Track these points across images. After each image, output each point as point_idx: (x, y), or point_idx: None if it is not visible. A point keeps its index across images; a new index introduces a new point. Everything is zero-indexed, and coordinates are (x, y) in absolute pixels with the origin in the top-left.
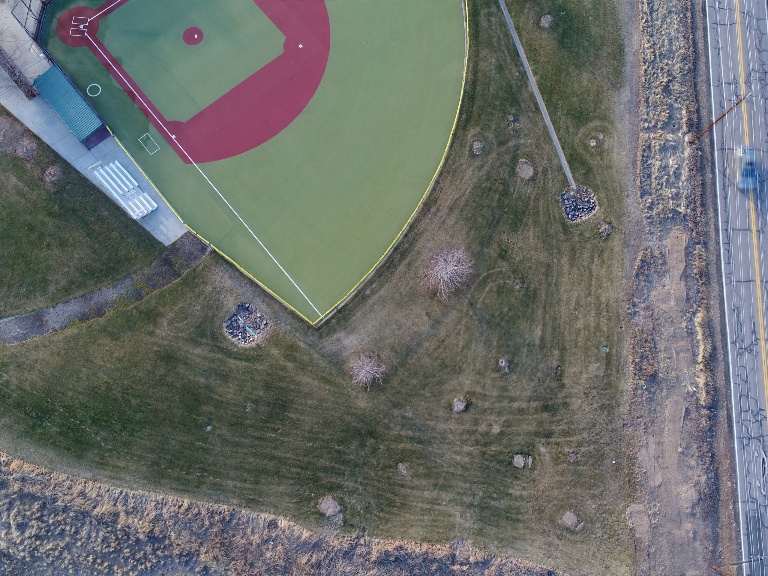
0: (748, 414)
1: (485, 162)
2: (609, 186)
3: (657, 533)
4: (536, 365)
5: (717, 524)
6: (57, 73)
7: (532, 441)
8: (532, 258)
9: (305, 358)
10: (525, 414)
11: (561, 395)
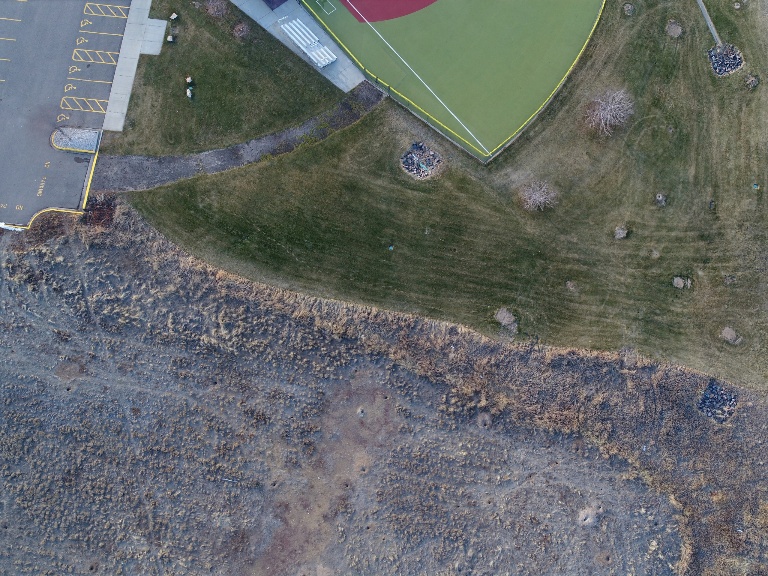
0: None
1: (636, 22)
2: (754, 44)
3: None
4: (691, 200)
5: None
6: None
7: (690, 265)
8: (683, 106)
9: (476, 190)
10: (682, 242)
11: (716, 226)
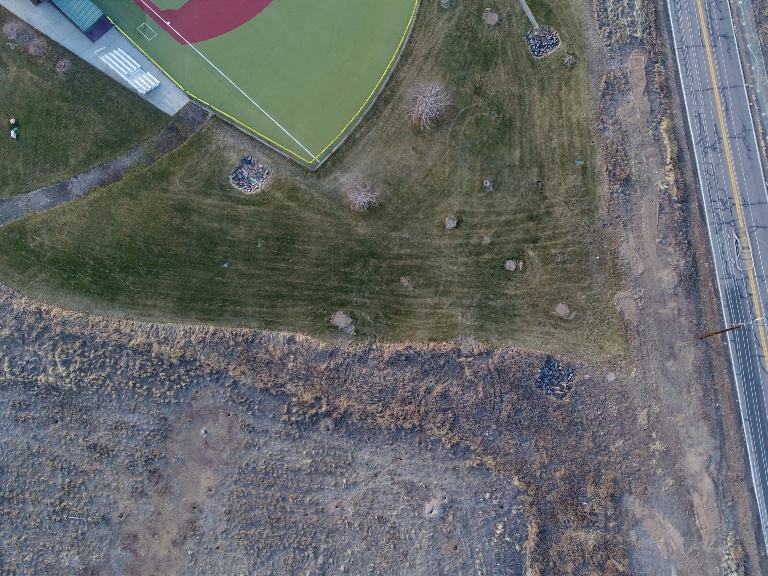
0: (718, 203)
1: (453, 14)
2: (569, 23)
3: (644, 314)
4: (518, 182)
5: (699, 301)
6: None
7: (521, 247)
8: (505, 92)
9: (306, 197)
10: (512, 225)
11: (544, 206)
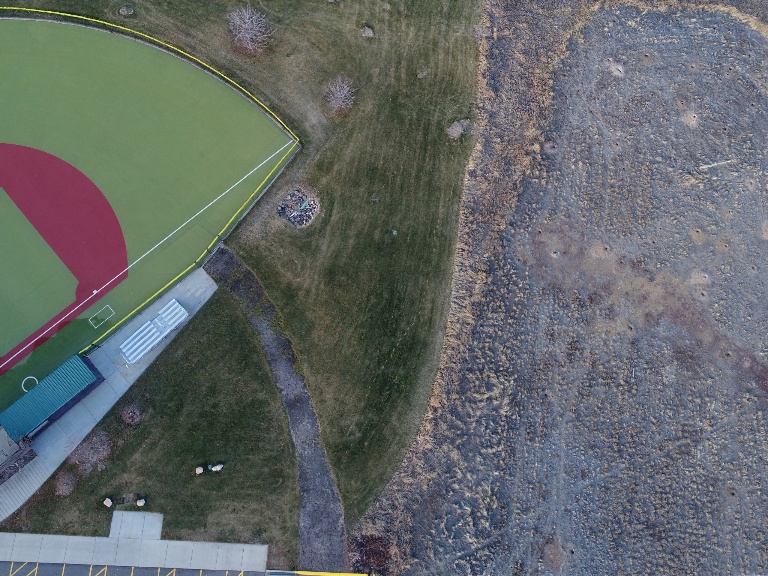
0: None
1: (142, 6)
2: None
3: None
4: None
5: None
6: (7, 413)
7: None
8: None
9: (329, 154)
10: None
11: None
